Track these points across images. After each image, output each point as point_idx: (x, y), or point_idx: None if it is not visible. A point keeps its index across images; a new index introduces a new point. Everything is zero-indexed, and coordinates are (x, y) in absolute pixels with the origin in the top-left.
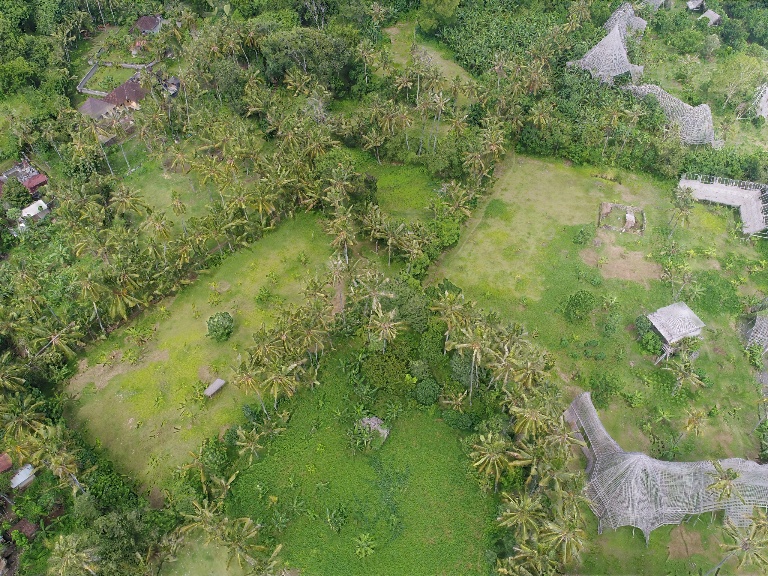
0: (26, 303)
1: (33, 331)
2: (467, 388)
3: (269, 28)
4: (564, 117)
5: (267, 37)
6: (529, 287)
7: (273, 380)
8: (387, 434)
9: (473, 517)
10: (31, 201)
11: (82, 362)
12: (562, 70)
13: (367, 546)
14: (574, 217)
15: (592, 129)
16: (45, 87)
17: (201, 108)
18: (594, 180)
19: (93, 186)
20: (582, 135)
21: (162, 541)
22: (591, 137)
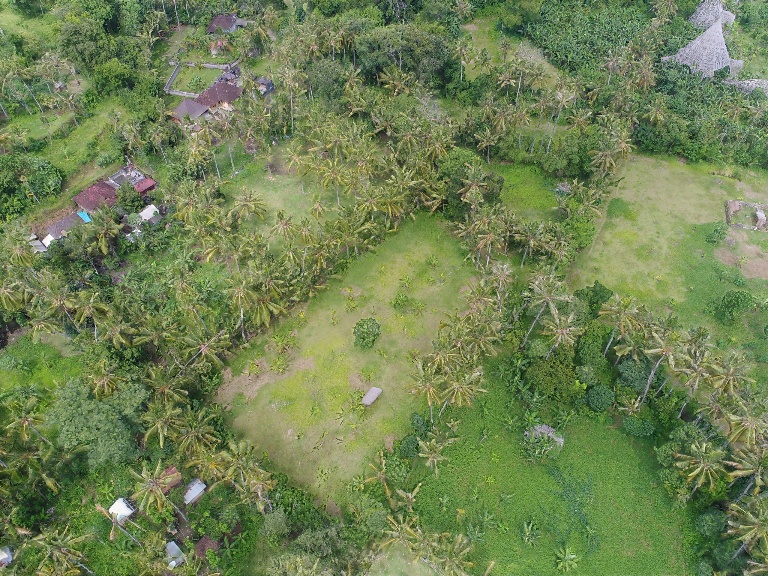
0: (187, 312)
1: (184, 341)
2: (640, 394)
3: (362, 26)
4: (673, 113)
5: (359, 35)
6: (671, 288)
7: (454, 389)
8: (563, 442)
9: (668, 528)
10: (143, 206)
11: (226, 371)
12: (658, 65)
13: (571, 560)
14: (701, 215)
15: (709, 125)
16: (139, 89)
17: (307, 108)
18: (714, 177)
19: (210, 190)
20: (701, 131)
21: (363, 558)
22: (708, 133)
